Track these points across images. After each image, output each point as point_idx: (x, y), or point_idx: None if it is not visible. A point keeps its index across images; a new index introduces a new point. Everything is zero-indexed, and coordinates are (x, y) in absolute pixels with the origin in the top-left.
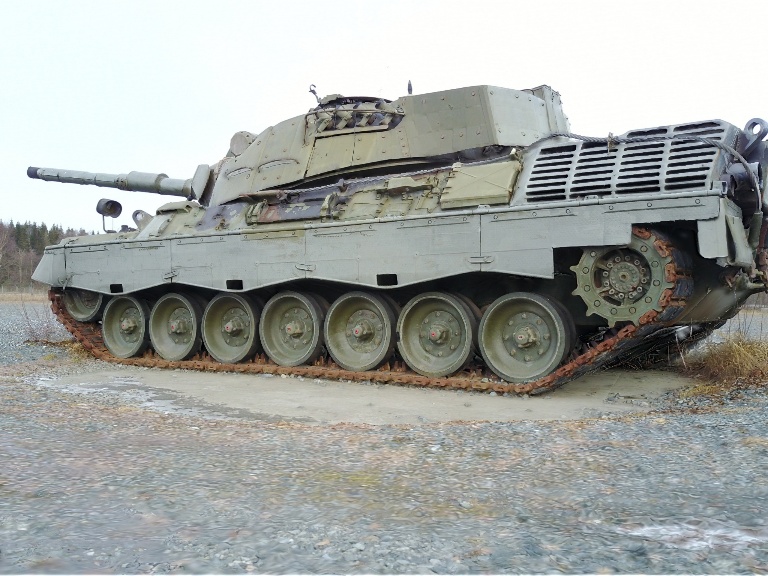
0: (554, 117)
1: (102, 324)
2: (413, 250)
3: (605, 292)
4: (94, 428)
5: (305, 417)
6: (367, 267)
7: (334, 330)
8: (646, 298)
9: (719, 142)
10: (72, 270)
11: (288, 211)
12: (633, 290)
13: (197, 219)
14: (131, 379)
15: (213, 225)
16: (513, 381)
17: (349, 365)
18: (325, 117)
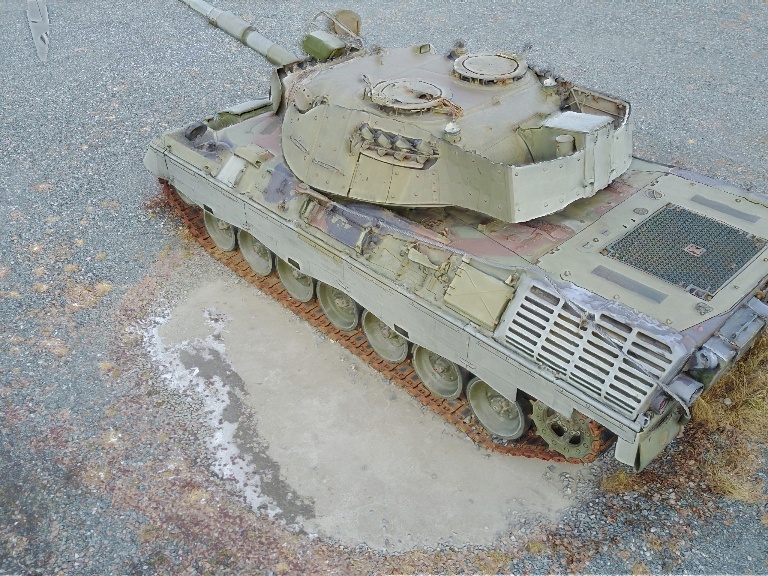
0: (592, 163)
1: (203, 216)
2: (420, 325)
3: (554, 421)
4: (167, 573)
5: (310, 503)
6: (387, 315)
7: (370, 321)
8: (577, 449)
9: (657, 381)
10: (173, 174)
11: (334, 221)
12: (574, 430)
13: (265, 183)
14: (220, 330)
15: (277, 200)
16: (486, 429)
17: (379, 353)
18: (368, 138)
